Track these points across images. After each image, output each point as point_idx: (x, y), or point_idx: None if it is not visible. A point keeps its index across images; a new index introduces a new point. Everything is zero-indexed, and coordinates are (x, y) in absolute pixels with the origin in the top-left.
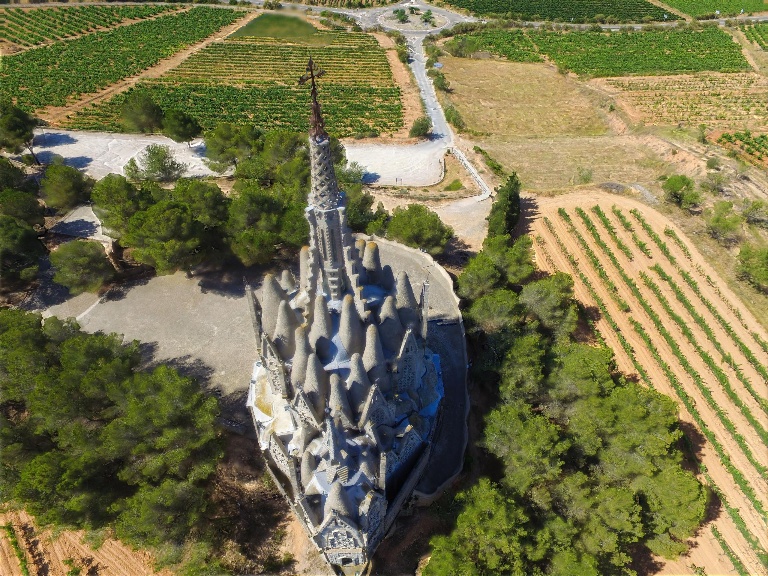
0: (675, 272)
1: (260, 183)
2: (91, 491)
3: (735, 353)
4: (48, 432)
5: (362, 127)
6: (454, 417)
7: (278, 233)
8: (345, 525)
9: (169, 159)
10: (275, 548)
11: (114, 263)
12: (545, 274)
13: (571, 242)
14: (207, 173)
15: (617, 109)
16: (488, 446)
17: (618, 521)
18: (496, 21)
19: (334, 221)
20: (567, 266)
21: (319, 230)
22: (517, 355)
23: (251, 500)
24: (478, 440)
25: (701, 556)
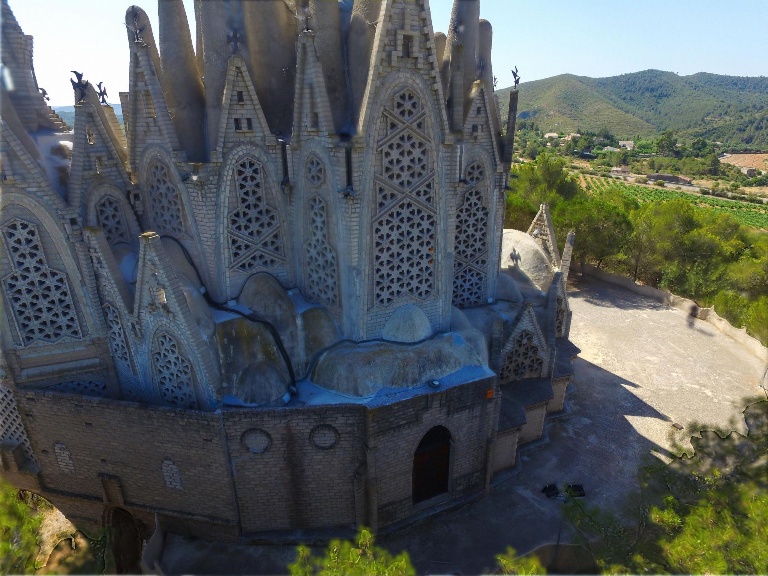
0: None
1: None
2: None
3: None
4: None
5: None
6: (407, 569)
7: None
8: None
9: None
10: None
11: None
12: None
13: None
14: None
15: None
16: None
17: None
18: None
19: None
20: None
21: None
22: (701, 540)
23: None
24: None
25: None
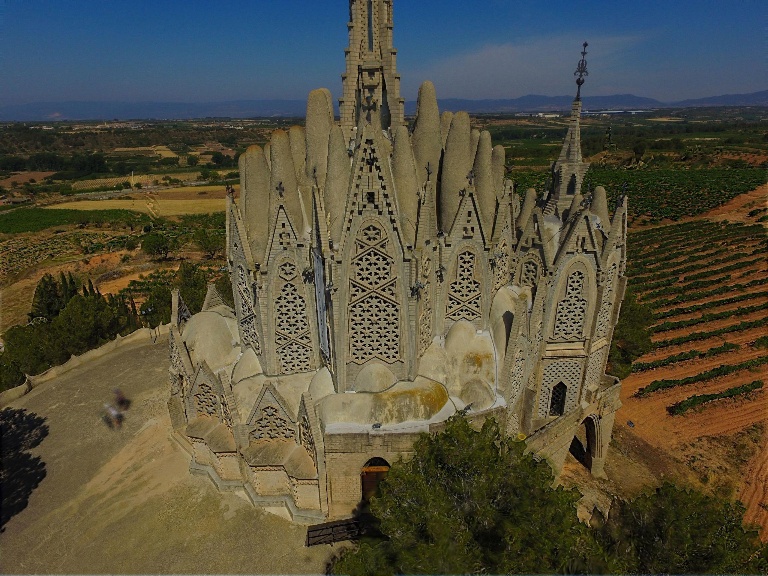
0: None
1: None
2: None
3: None
4: None
5: None
6: None
7: None
8: None
9: None
10: None
11: None
12: None
13: None
14: None
15: None
16: None
17: None
18: None
19: None
20: None
21: None
22: None
23: None
24: None
25: None
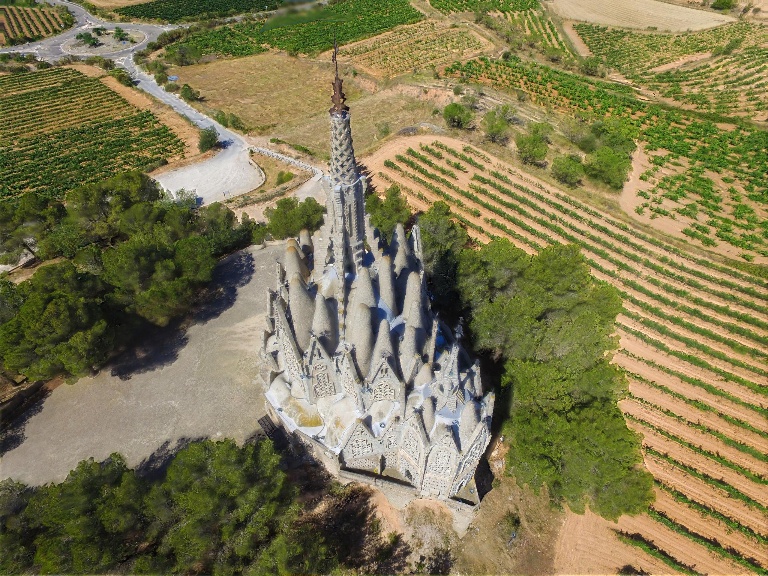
0: (488, 175)
1: (99, 246)
2: None
3: (554, 212)
4: None
5: (140, 160)
6: None
7: (178, 278)
8: (484, 433)
9: None
10: (377, 539)
11: None
12: None
13: (409, 184)
14: None
15: (359, 73)
16: (484, 346)
17: (592, 337)
18: (197, 23)
19: (358, 192)
20: (420, 202)
21: (347, 207)
22: (466, 268)
23: (329, 519)
24: None
25: None
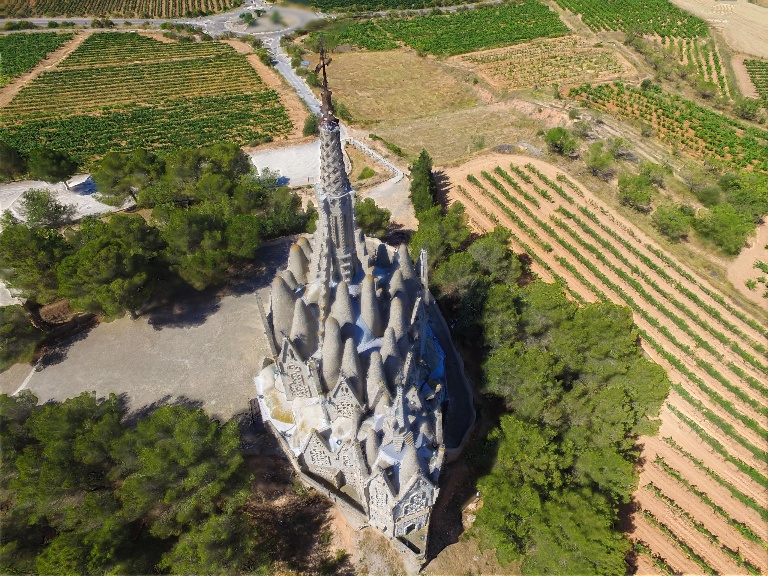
0: (575, 210)
1: (177, 206)
2: (122, 560)
3: (639, 264)
4: (46, 518)
5: (251, 135)
6: (452, 376)
7: None
8: (424, 484)
9: (52, 203)
10: (325, 551)
11: (36, 325)
12: (475, 235)
13: (487, 203)
14: (99, 211)
15: (480, 81)
16: (492, 390)
17: (616, 415)
18: (345, 15)
19: (347, 206)
20: (490, 224)
21: (332, 218)
22: (494, 304)
23: (285, 515)
24: (476, 390)
25: (666, 429)
